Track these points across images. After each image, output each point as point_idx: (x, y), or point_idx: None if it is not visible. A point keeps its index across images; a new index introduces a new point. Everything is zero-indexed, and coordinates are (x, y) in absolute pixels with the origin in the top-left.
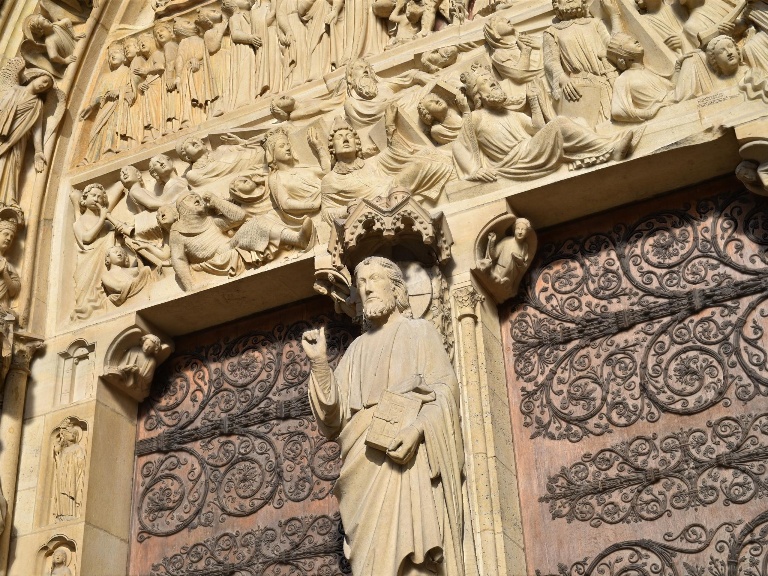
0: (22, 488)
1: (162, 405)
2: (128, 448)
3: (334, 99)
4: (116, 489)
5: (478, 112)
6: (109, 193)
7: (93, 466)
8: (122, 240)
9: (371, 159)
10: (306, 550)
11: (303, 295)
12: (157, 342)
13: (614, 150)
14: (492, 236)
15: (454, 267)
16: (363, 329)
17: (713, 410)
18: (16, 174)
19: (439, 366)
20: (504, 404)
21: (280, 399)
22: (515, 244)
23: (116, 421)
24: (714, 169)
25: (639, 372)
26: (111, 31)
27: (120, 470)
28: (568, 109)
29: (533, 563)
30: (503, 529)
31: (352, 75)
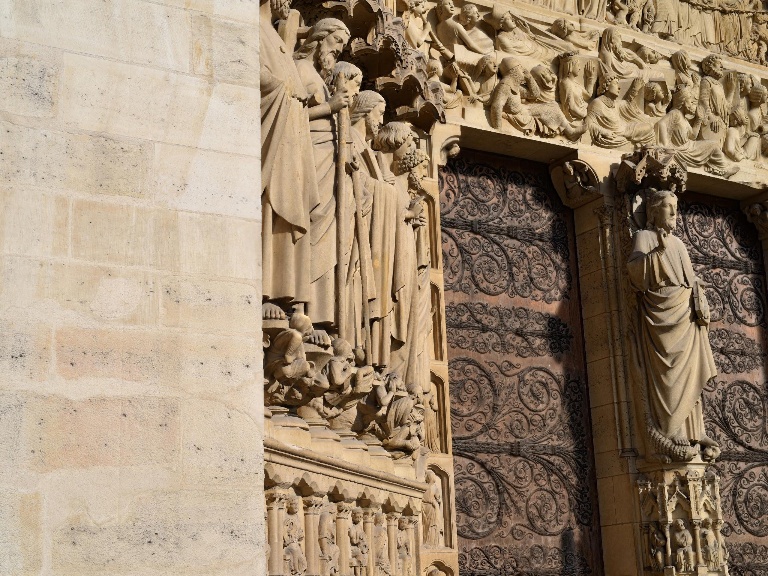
0: None
1: None
2: None
3: None
4: None
5: None
6: None
7: None
8: None
9: None
10: (532, 331)
11: (530, 157)
12: None
13: (727, 172)
14: None
15: None
16: (630, 222)
17: (719, 323)
18: None
19: None
20: None
21: (508, 222)
22: None
23: None
24: None
25: None
26: None
27: None
28: (709, 134)
29: None
30: None
31: (614, 38)
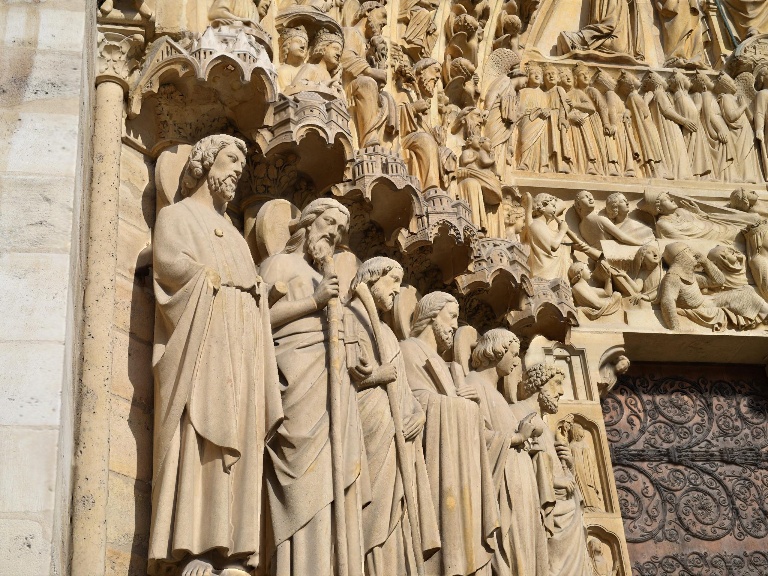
0: None
1: None
2: None
3: None
4: None
5: None
6: None
7: None
8: (573, 256)
9: None
10: None
11: (735, 360)
12: None
13: None
14: None
15: None
16: None
17: None
18: None
19: None
20: None
21: (719, 444)
22: None
23: None
24: None
25: None
26: (526, 49)
27: None
28: None
29: None
30: None
31: None
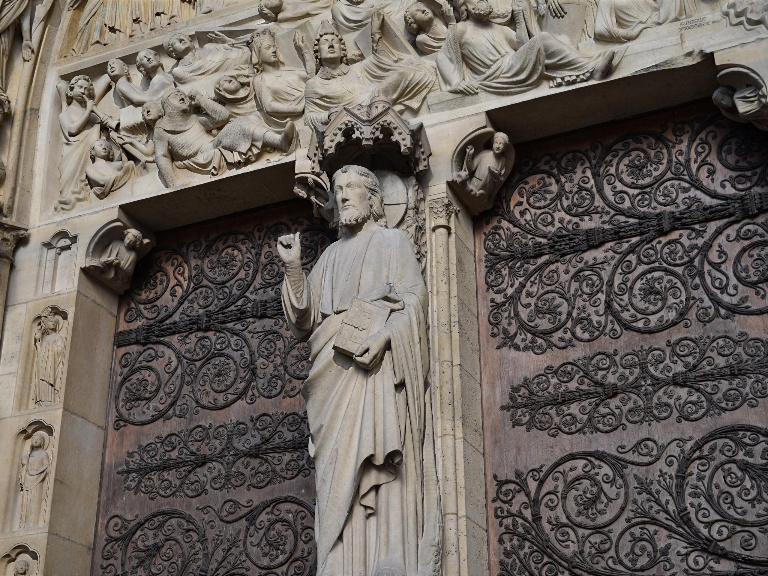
0: (3, 373)
1: (142, 298)
2: (107, 338)
3: (322, 2)
4: (94, 378)
5: (463, 24)
6: (96, 85)
7: (72, 355)
8: (107, 133)
9: (356, 65)
10: (275, 445)
11: (284, 197)
12: (139, 237)
13: (595, 69)
14: (470, 149)
15: (431, 178)
16: (339, 235)
17: (673, 330)
18: (3, 62)
19: (409, 276)
20: (473, 314)
21: (257, 298)
22: (492, 158)
23: (96, 312)
24: (692, 93)
25: (605, 289)
26: None
27: (99, 360)
28: (552, 25)
29: (491, 468)
30: (463, 435)
31: None
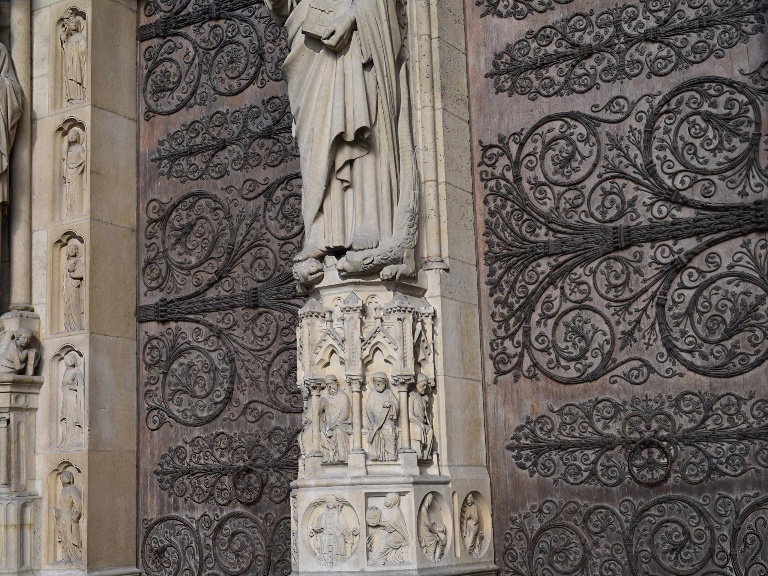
0: (37, 75)
1: None
2: (130, 34)
3: None
4: (120, 73)
5: None
6: None
7: (95, 53)
8: None
9: None
10: (285, 125)
11: None
12: None
13: None
14: None
15: None
16: None
17: None
18: None
19: None
20: None
21: None
22: None
23: (115, 9)
24: None
25: None
26: None
27: (123, 55)
28: None
29: (477, 134)
30: (443, 105)
31: None
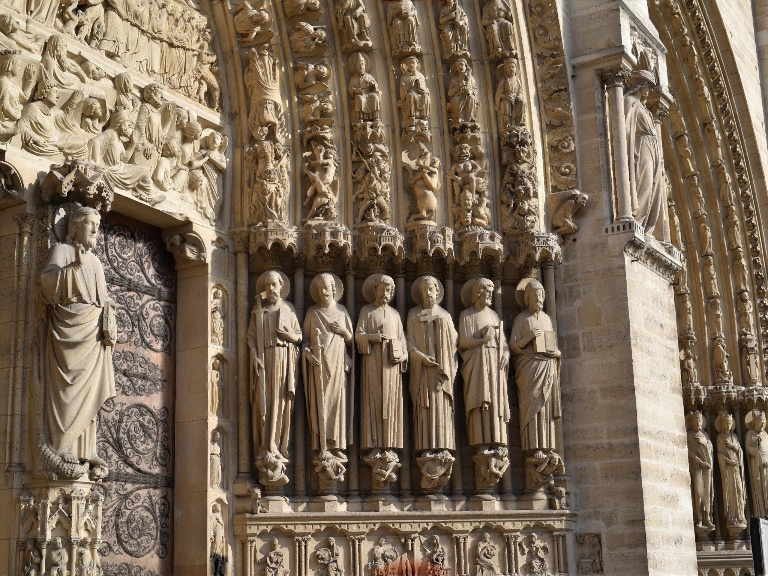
0: None
1: None
2: None
3: None
4: None
5: None
6: None
7: None
8: None
9: (51, 110)
10: None
11: None
12: None
13: (154, 199)
14: None
15: None
16: None
17: None
18: None
19: None
20: None
21: None
22: None
23: None
24: (158, 223)
25: None
26: None
27: None
28: (141, 159)
29: None
30: None
31: (60, 46)
